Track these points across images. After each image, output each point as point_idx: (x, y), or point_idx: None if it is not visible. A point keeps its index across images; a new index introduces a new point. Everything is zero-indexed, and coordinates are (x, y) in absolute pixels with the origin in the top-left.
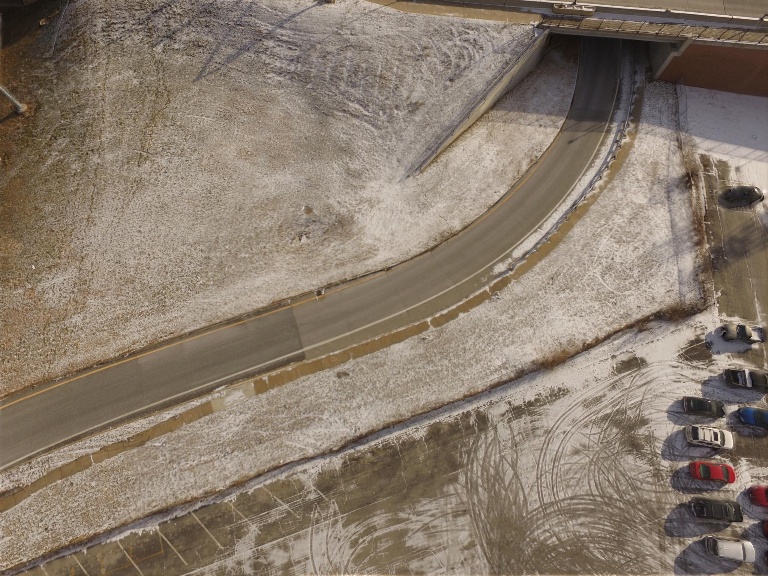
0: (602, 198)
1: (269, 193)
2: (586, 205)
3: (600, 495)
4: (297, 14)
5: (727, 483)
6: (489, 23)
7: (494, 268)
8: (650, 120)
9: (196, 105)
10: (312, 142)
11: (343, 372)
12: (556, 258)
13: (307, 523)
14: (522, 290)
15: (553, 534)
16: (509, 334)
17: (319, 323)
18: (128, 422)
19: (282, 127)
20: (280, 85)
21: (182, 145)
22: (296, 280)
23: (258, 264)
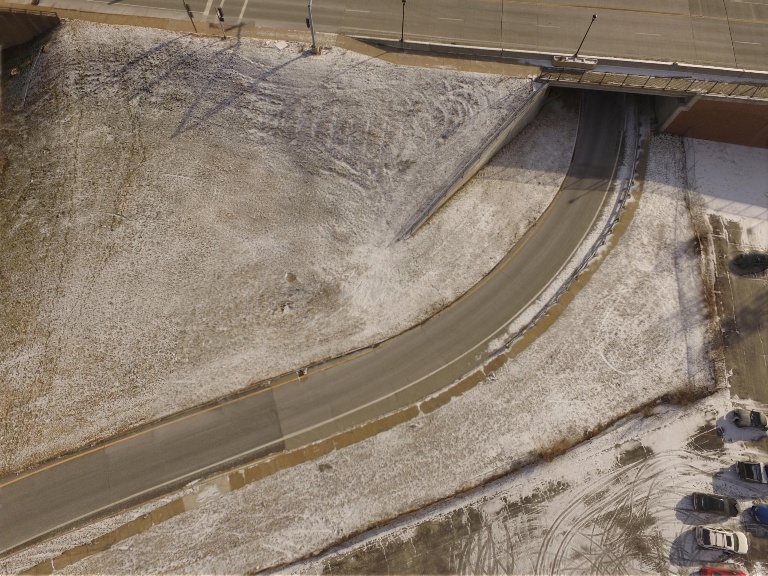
0: (605, 265)
1: (250, 259)
2: (588, 273)
3: None
4: (280, 66)
5: None
6: (484, 76)
7: (489, 345)
8: (656, 177)
9: (173, 163)
10: (296, 203)
11: (326, 464)
12: (555, 334)
13: None
14: (519, 370)
15: None
16: (505, 421)
17: (301, 408)
18: (93, 522)
19: (264, 187)
20: (263, 141)
21: (158, 207)
22: (277, 358)
23: (237, 339)
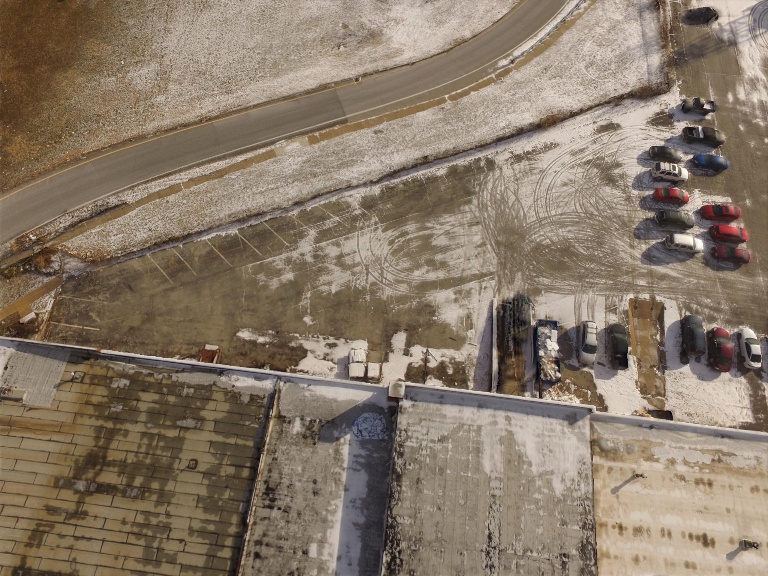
0: (586, 15)
1: (312, 13)
2: (573, 19)
3: (583, 212)
4: None
5: (683, 205)
6: None
7: (498, 63)
8: None
9: None
10: None
11: (379, 130)
12: (549, 55)
13: (354, 229)
14: (521, 76)
15: (547, 237)
16: (511, 106)
17: (358, 99)
18: (209, 163)
19: None
20: None
21: None
22: (338, 71)
23: (306, 63)
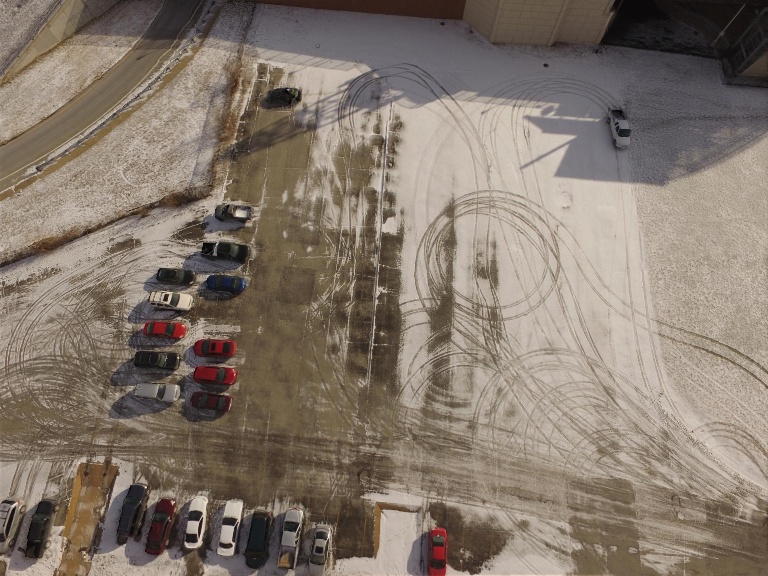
0: (146, 105)
1: None
2: (129, 112)
3: (61, 355)
4: None
5: (179, 339)
6: None
7: (27, 170)
8: (217, 35)
9: None
10: None
11: None
12: (85, 158)
13: None
14: (44, 187)
15: (9, 389)
16: (19, 225)
17: None
18: None
19: None
20: None
21: None
22: None
23: None
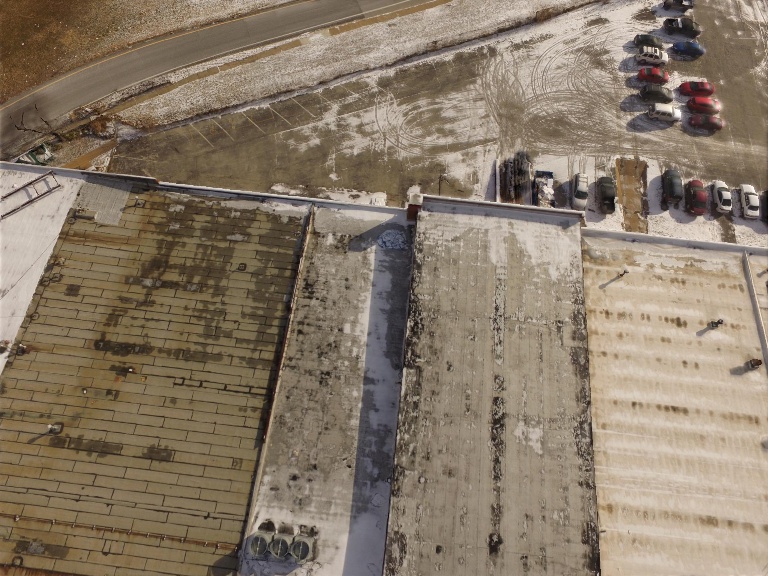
0: None
1: None
2: None
3: (576, 90)
4: None
5: (664, 84)
6: None
7: None
8: None
9: None
10: None
11: (392, 24)
12: None
13: (372, 104)
14: None
15: (543, 110)
16: (510, 4)
17: None
18: (241, 51)
19: None
20: None
21: None
22: None
23: None
